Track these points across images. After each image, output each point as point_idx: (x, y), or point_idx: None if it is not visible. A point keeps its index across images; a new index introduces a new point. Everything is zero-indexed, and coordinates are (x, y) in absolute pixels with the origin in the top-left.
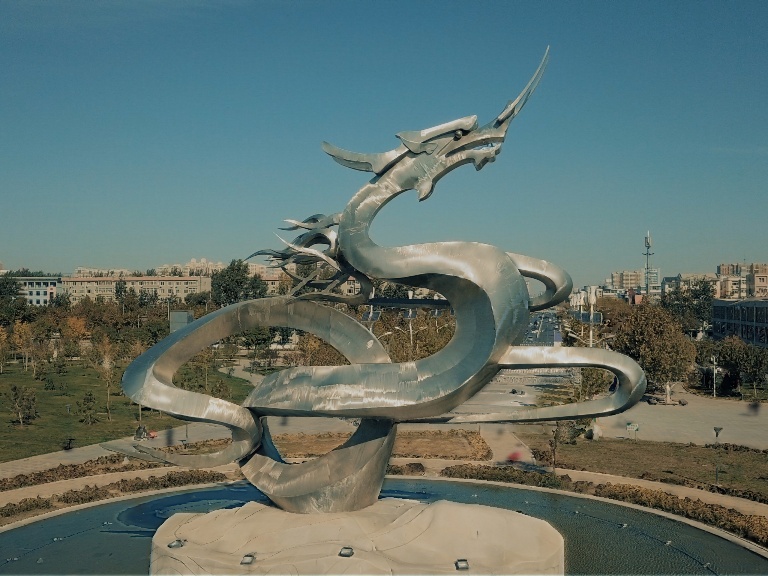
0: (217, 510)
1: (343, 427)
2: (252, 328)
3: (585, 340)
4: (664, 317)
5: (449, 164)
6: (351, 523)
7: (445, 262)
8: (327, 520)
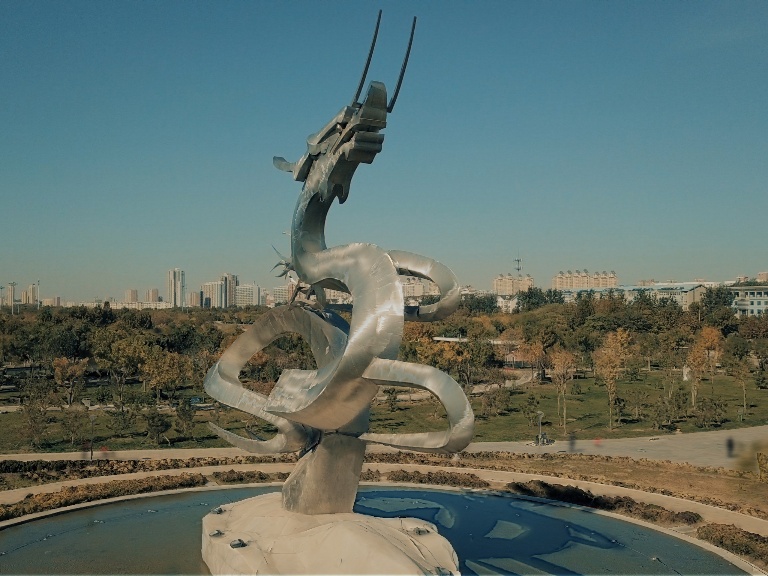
0: (280, 494)
1: None
2: (281, 332)
3: None
4: None
5: (334, 161)
6: (282, 523)
7: (337, 266)
8: None
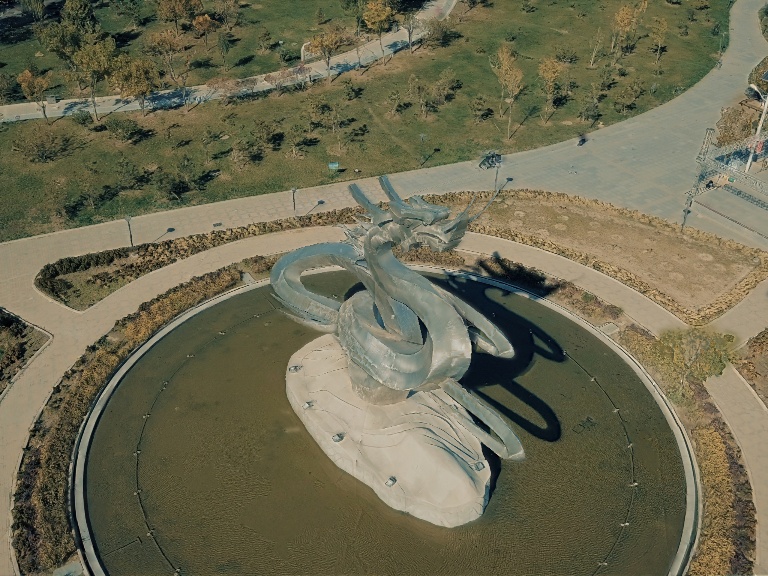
0: (336, 350)
1: (672, 198)
2: None
3: None
4: None
5: (418, 241)
6: (362, 416)
7: (416, 303)
8: (354, 405)
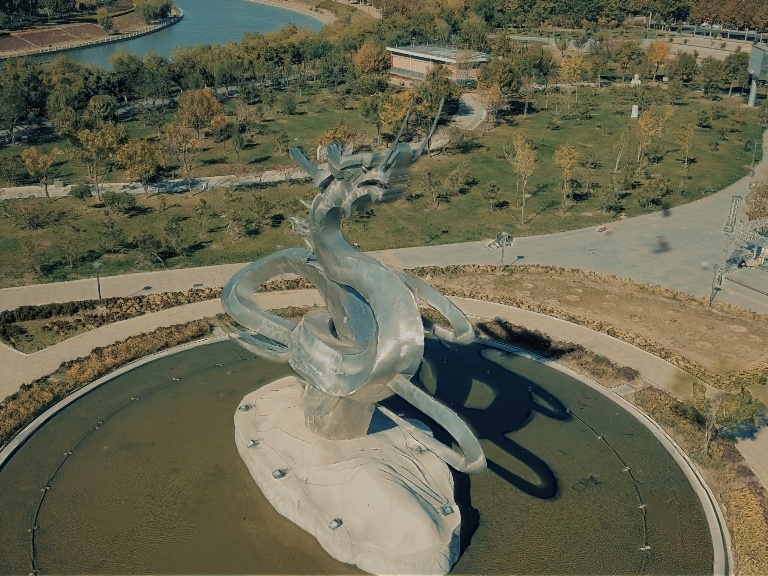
0: (296, 389)
1: (700, 277)
2: None
3: None
4: None
5: (359, 195)
6: (311, 450)
7: (361, 282)
8: (304, 439)
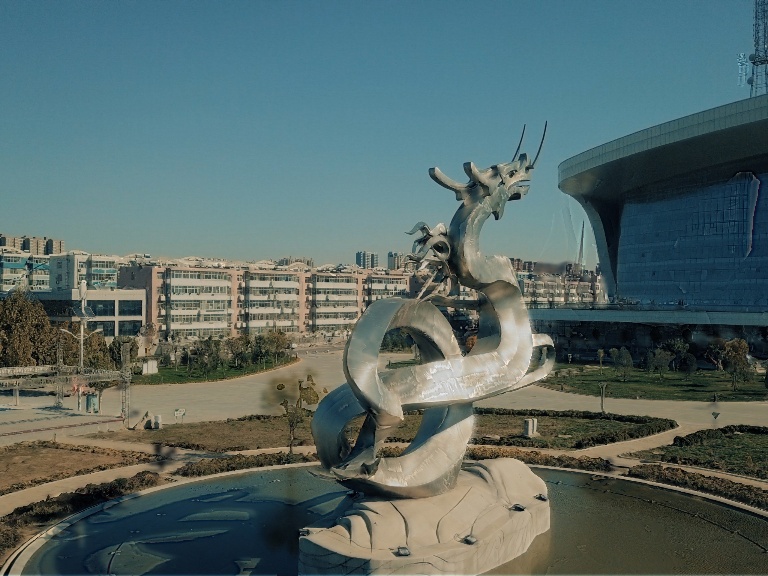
0: (352, 519)
1: None
2: None
3: (77, 335)
4: (39, 310)
5: (510, 195)
6: None
7: None
8: (466, 493)
